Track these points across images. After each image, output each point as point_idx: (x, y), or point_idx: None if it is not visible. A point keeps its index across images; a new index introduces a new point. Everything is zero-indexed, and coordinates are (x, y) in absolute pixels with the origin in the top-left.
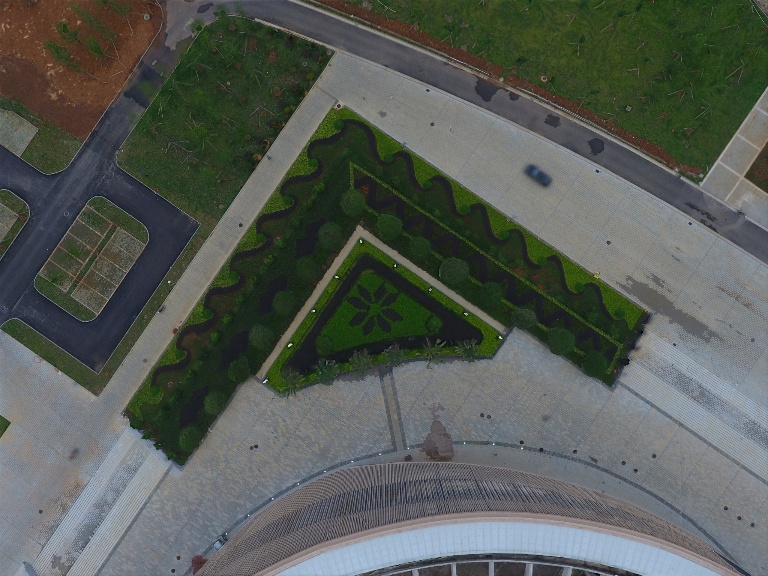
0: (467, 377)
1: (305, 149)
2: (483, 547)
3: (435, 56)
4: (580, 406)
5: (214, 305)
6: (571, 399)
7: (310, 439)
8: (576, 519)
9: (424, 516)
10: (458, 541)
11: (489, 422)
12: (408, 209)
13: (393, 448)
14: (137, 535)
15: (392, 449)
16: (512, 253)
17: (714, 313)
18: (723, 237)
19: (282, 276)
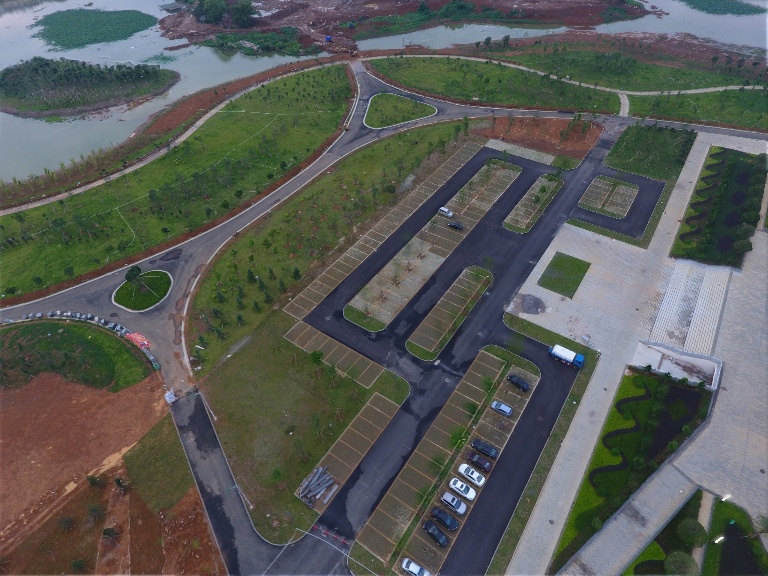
0: None
1: (708, 157)
2: None
3: (751, 132)
4: None
5: None
6: None
7: None
8: None
9: None
10: None
11: None
12: None
13: None
14: (733, 309)
15: None
16: None
17: None
18: None
19: (738, 191)
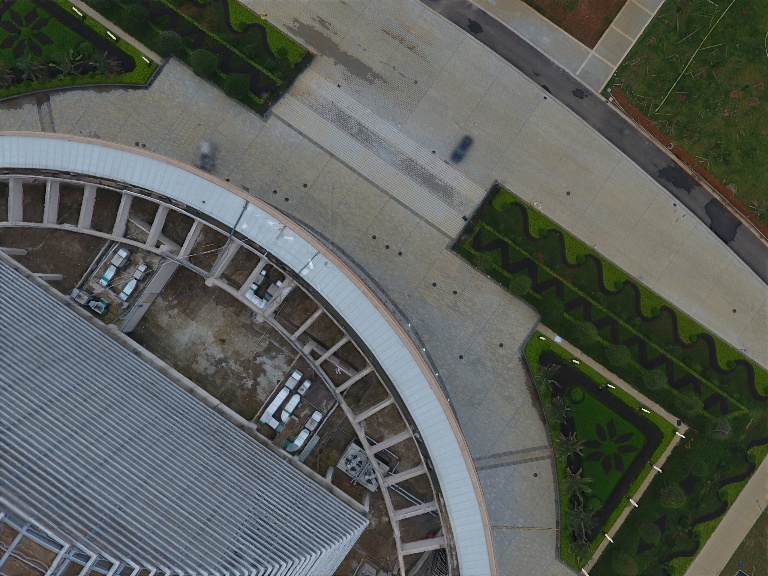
0: (123, 106)
1: None
2: None
3: None
4: (234, 136)
5: None
6: (225, 129)
7: None
8: None
9: None
10: None
11: None
12: None
13: None
14: None
15: None
16: None
17: (378, 55)
18: None
19: None
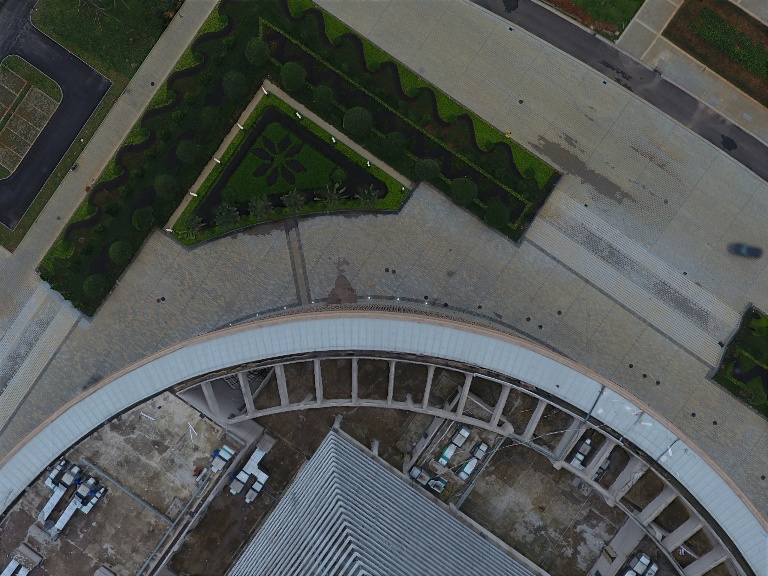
0: (372, 232)
1: (216, 6)
2: (343, 343)
3: None
4: (485, 262)
5: (125, 162)
6: (476, 255)
7: (216, 292)
8: (438, 318)
9: (287, 315)
10: (319, 337)
11: (394, 277)
12: (317, 65)
13: (298, 302)
14: (47, 384)
15: (297, 303)
16: (422, 111)
17: (627, 174)
18: (638, 96)
19: (190, 130)
